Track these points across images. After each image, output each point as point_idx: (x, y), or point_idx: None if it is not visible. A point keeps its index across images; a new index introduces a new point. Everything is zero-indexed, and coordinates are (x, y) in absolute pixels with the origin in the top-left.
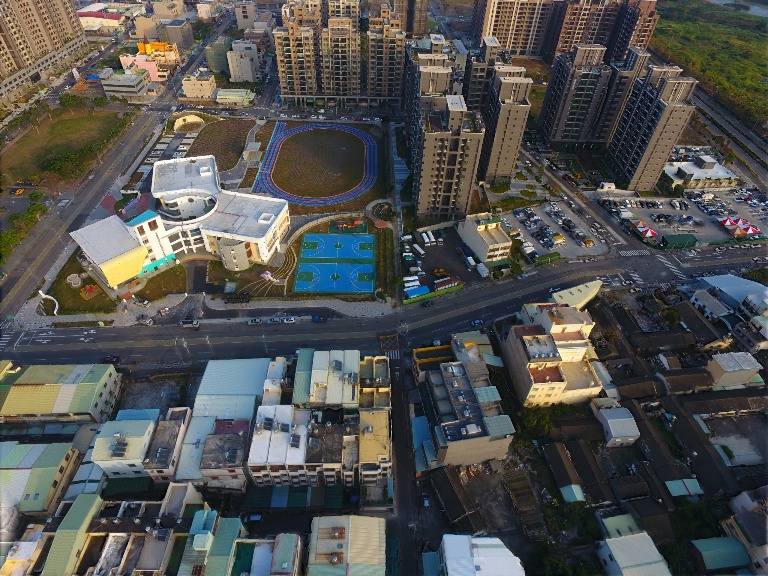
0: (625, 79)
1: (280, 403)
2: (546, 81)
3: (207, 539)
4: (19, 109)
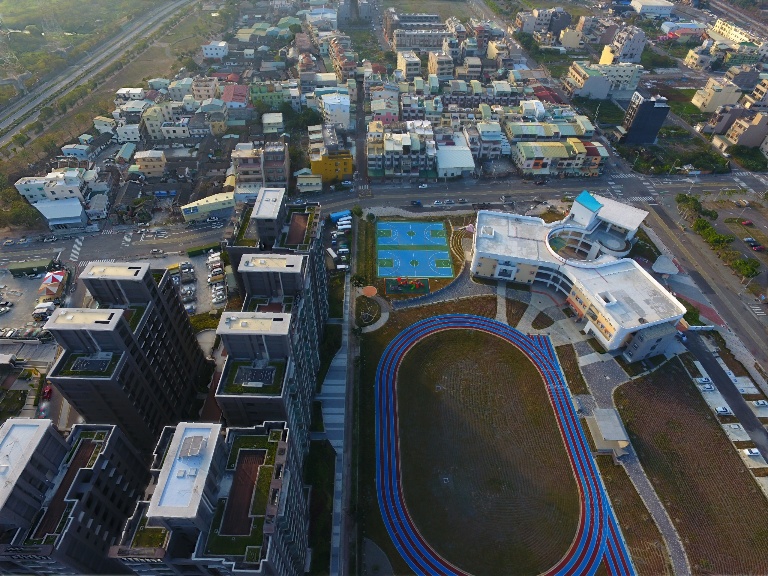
0: None
1: None
2: None
3: None
4: None
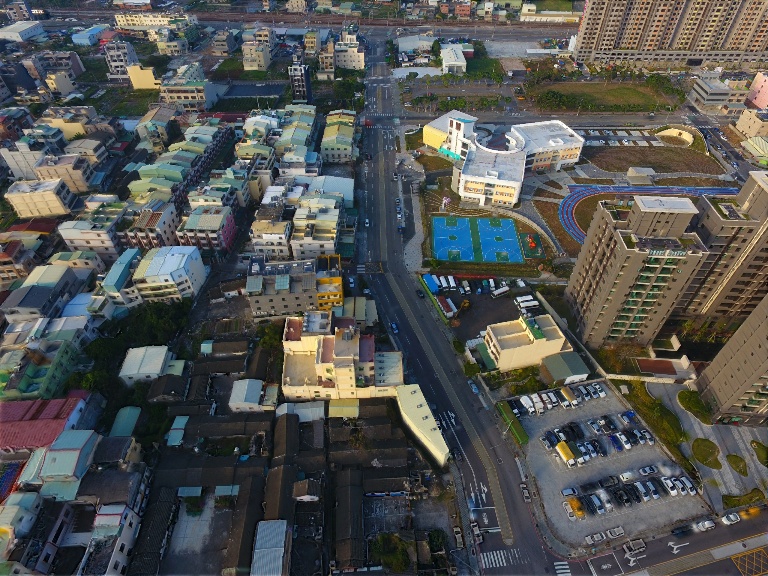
0: None
1: None
2: None
3: (229, 171)
4: (637, 72)
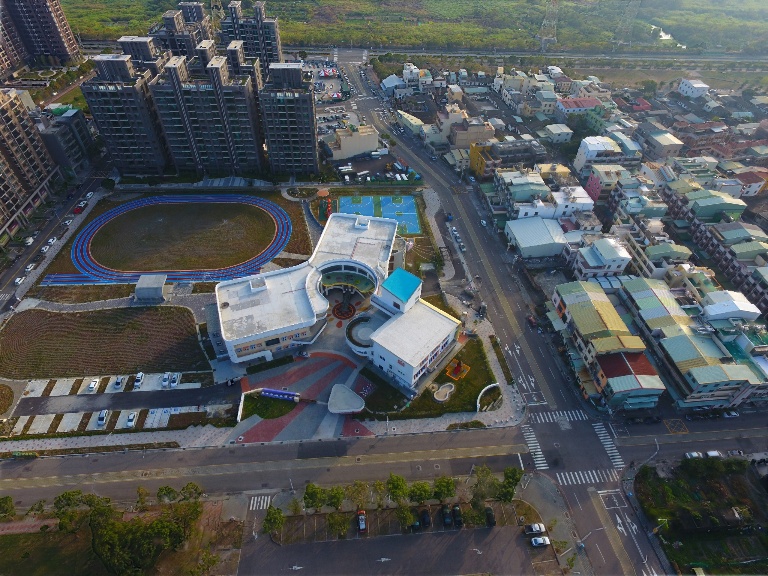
0: (205, 28)
1: (547, 204)
2: (56, 90)
3: None
4: None
